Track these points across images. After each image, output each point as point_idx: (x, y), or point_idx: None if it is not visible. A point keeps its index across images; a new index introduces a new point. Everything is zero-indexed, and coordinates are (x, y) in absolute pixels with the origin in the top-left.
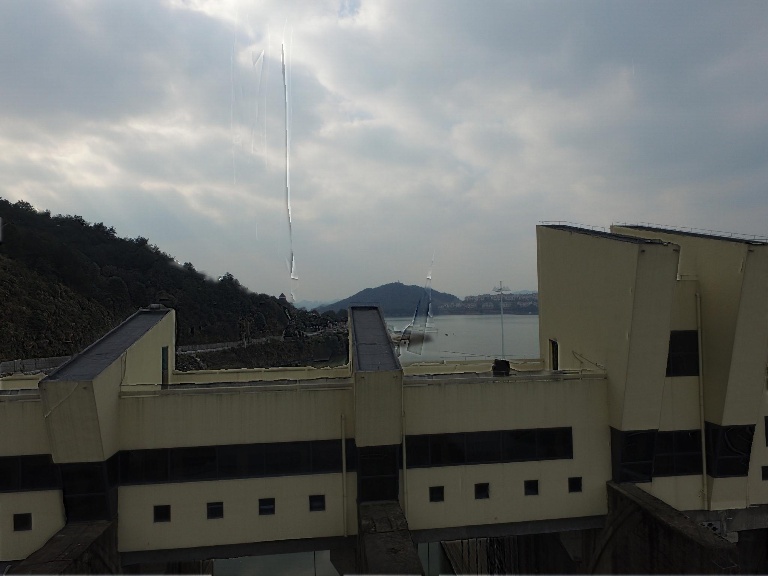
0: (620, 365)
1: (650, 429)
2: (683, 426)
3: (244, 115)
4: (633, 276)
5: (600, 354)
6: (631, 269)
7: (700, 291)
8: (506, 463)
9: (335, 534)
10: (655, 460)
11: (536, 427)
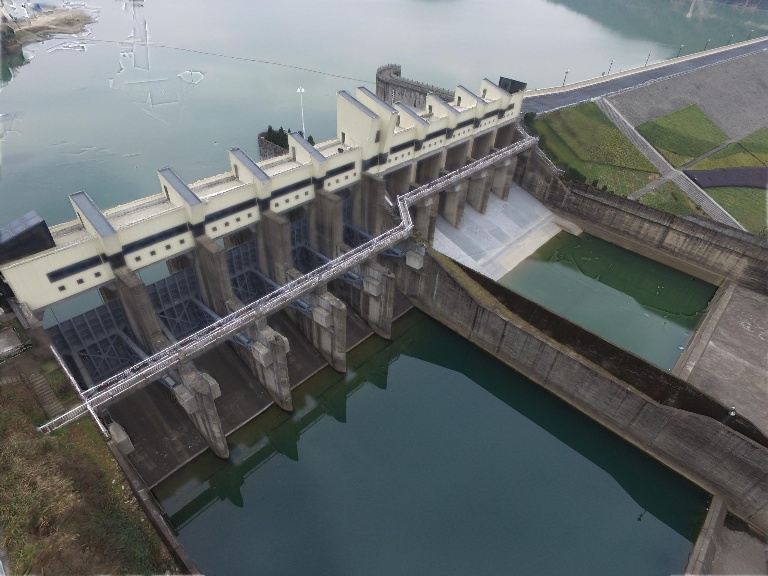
0: (366, 145)
1: (370, 158)
2: (375, 155)
3: None
4: (371, 126)
5: (360, 141)
6: (370, 124)
7: (381, 120)
8: (342, 173)
9: (310, 199)
10: None
11: (348, 163)
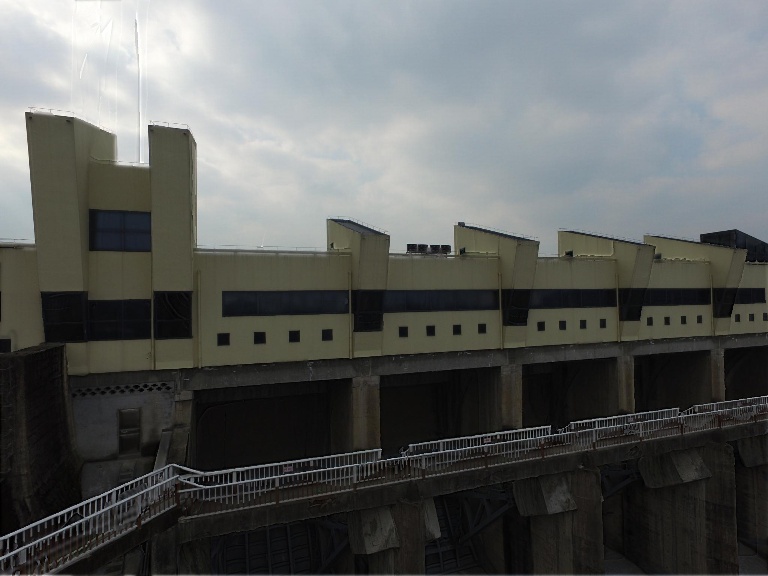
0: None
1: (73, 291)
2: (133, 296)
3: (89, 88)
4: None
5: None
6: None
7: None
8: None
9: None
10: (103, 326)
11: None
